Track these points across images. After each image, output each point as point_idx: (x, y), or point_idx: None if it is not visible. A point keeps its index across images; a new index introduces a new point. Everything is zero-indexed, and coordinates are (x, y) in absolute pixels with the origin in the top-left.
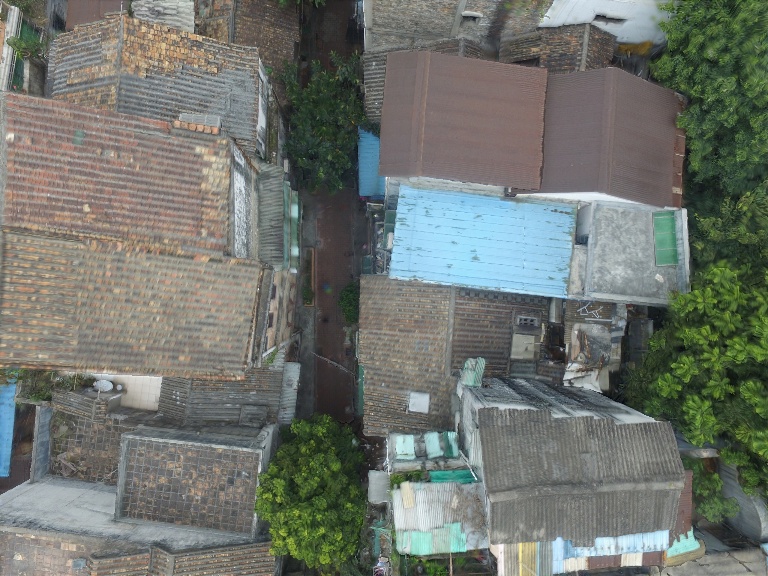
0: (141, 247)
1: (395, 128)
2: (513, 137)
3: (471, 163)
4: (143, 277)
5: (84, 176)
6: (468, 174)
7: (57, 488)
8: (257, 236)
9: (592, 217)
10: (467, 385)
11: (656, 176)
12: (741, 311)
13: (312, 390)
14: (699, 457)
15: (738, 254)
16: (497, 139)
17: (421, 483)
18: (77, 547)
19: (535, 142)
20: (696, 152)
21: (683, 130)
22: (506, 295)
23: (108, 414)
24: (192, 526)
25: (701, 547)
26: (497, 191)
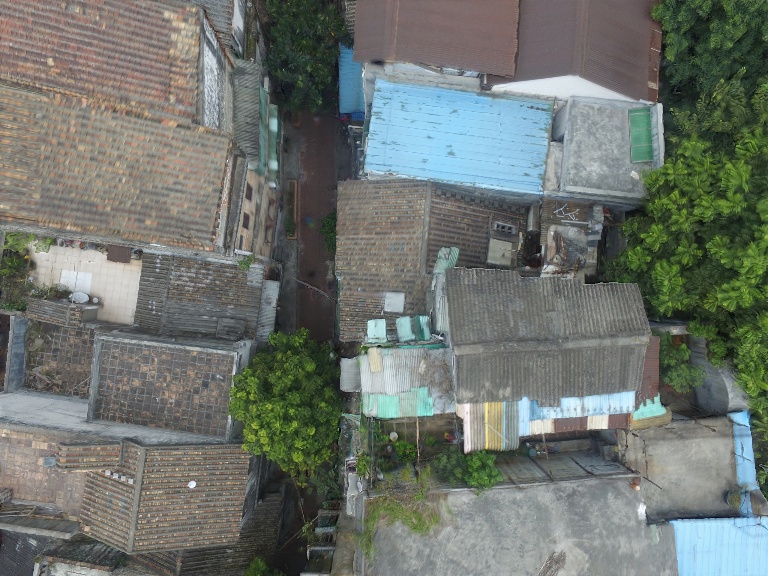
0: (107, 106)
1: (370, 13)
2: (488, 22)
3: (445, 47)
4: (109, 137)
5: (48, 29)
6: (442, 58)
7: (31, 398)
8: (232, 131)
9: (568, 113)
10: (440, 273)
11: (631, 67)
12: (710, 181)
13: (294, 323)
14: (668, 331)
15: (713, 148)
16: (472, 24)
17: (389, 349)
18: (48, 445)
19: (510, 28)
20: (672, 47)
21: (659, 24)
22: (483, 199)
23: (83, 323)
24: (166, 429)
25: (668, 413)
26: (473, 85)
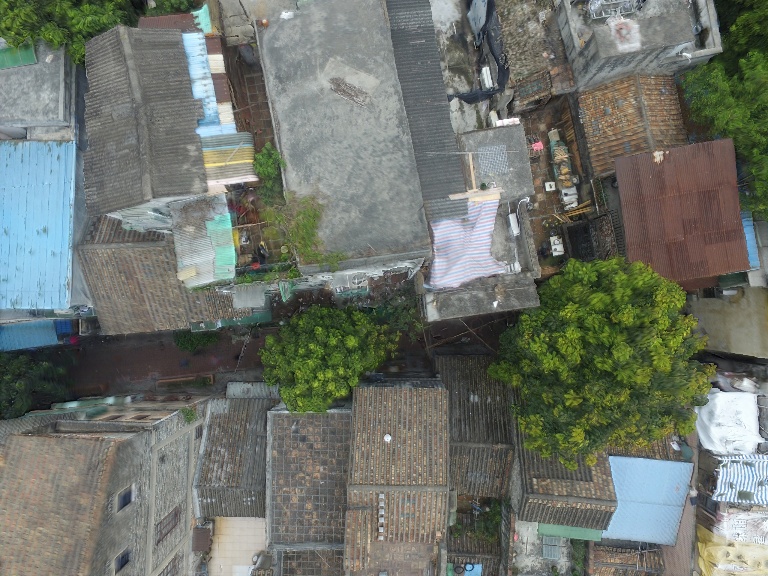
0: None
1: None
2: None
3: None
4: None
5: None
6: None
7: None
8: None
9: None
10: None
11: None
12: None
13: None
14: None
15: None
16: None
17: None
18: None
19: None
20: None
21: None
22: None
23: (271, 567)
24: None
25: (207, 3)
26: None
